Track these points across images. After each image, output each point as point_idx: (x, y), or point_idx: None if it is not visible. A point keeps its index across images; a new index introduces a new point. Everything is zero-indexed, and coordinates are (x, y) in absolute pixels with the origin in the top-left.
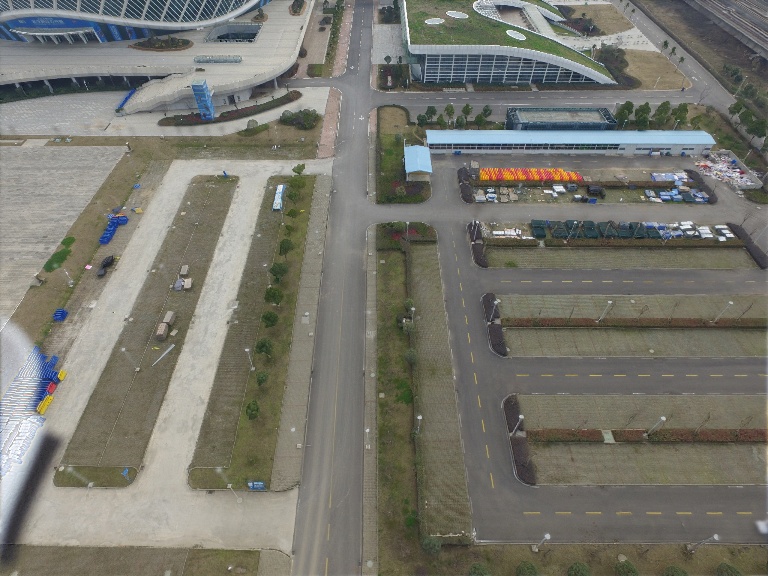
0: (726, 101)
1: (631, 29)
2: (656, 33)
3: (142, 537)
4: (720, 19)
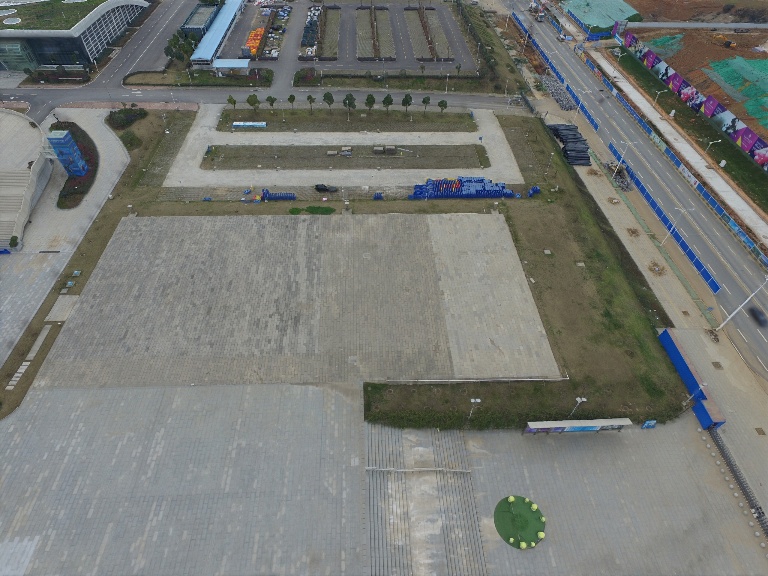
0: None
1: None
2: None
3: None
4: None
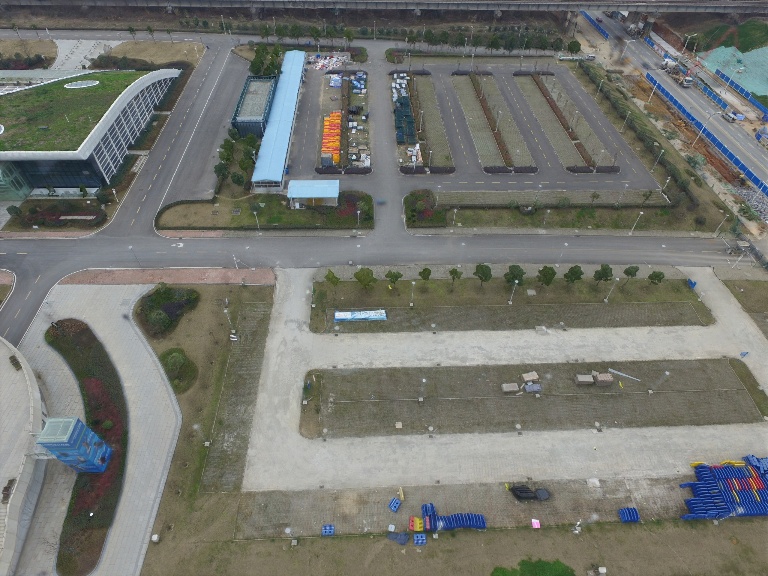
0: None
1: (56, 43)
2: (79, 34)
3: (763, 341)
4: None
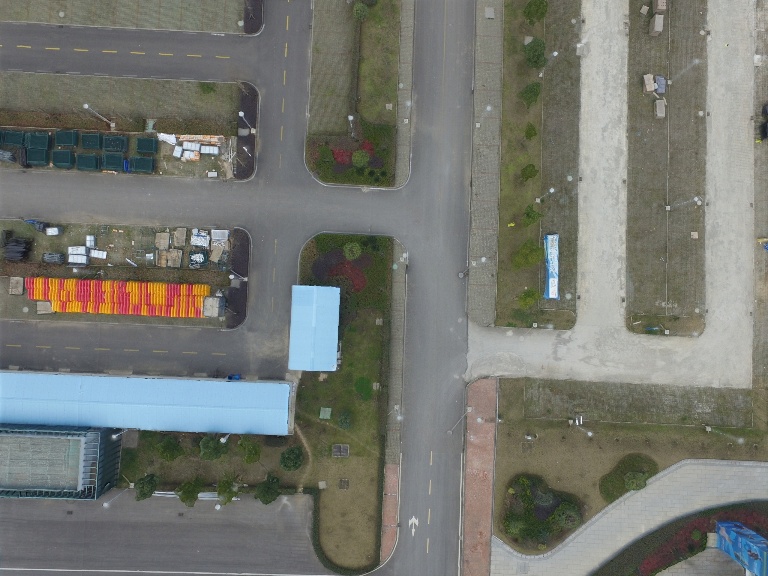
0: None
1: None
2: None
3: None
4: None
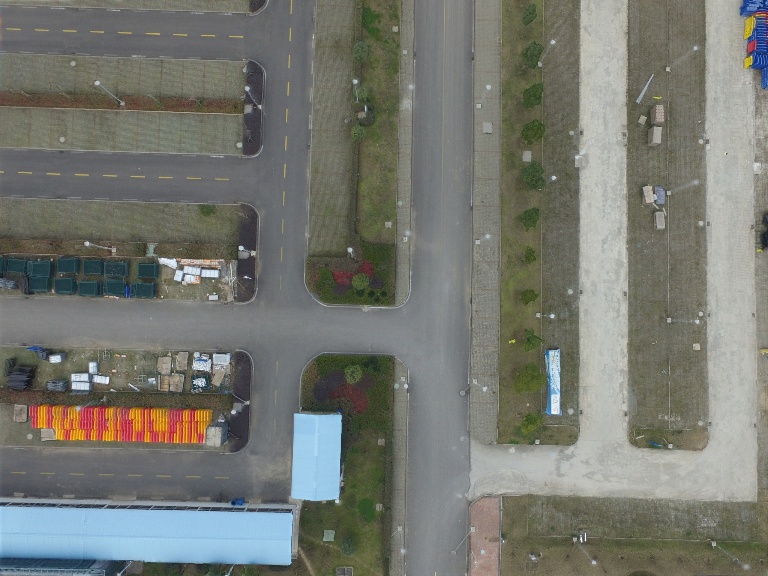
0: None
1: None
2: None
3: None
4: None
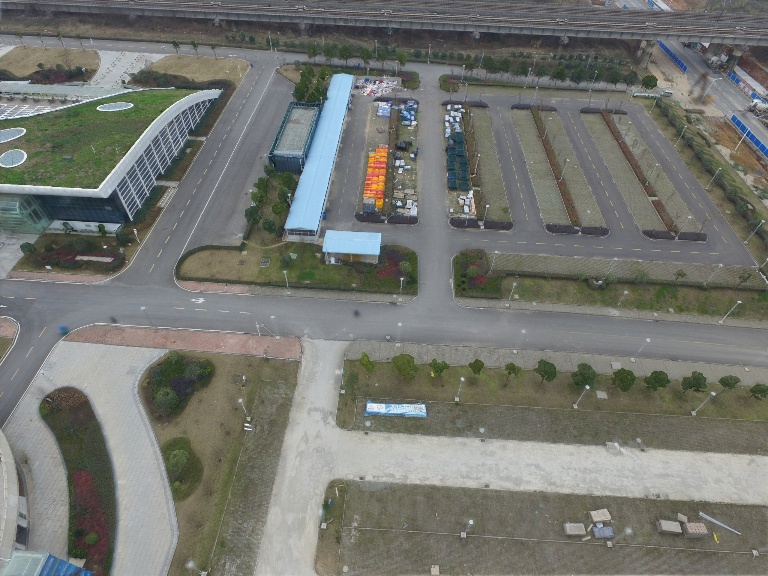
0: (278, 56)
1: (99, 54)
2: (123, 45)
3: None
4: (142, 9)
